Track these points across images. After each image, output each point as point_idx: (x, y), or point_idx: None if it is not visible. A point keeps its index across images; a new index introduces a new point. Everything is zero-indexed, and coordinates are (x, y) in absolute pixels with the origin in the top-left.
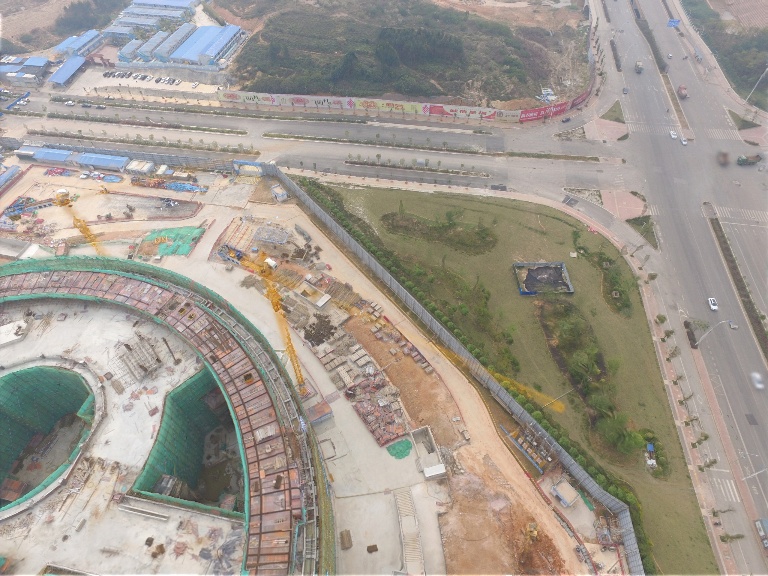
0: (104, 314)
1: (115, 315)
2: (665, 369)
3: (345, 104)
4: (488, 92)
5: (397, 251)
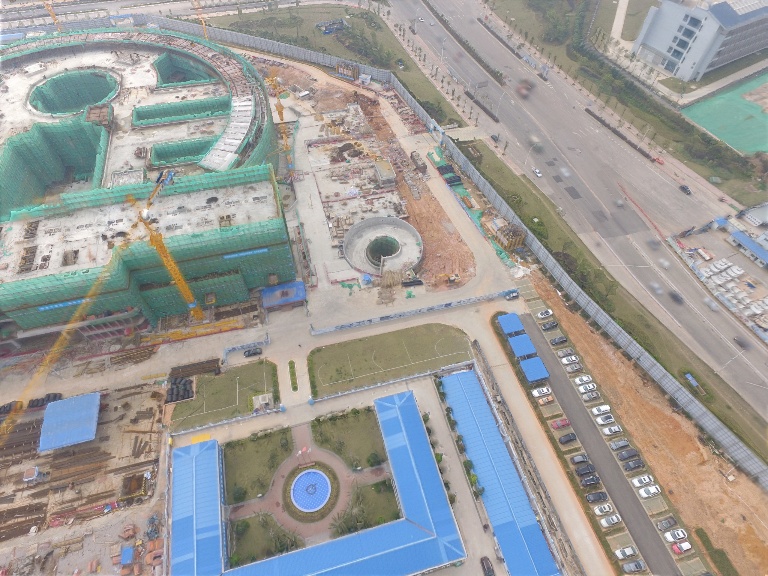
0: (89, 54)
1: (96, 53)
2: (403, 43)
3: None
4: None
5: None
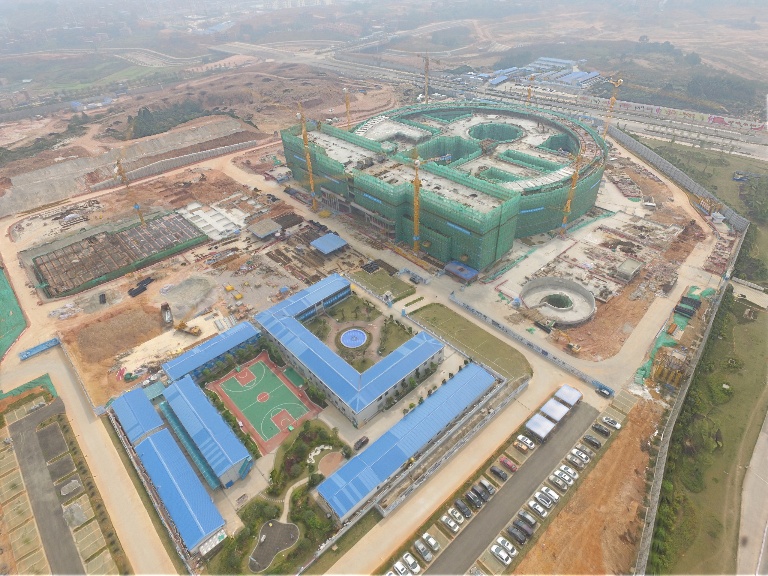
0: None
1: (531, 121)
2: None
3: (654, 110)
4: (763, 117)
5: None
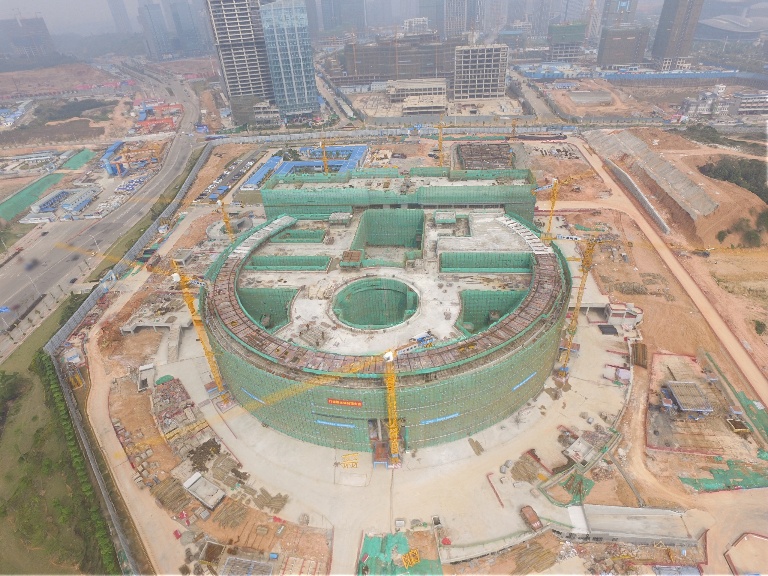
0: None
1: None
2: None
3: None
4: None
5: (73, 571)
